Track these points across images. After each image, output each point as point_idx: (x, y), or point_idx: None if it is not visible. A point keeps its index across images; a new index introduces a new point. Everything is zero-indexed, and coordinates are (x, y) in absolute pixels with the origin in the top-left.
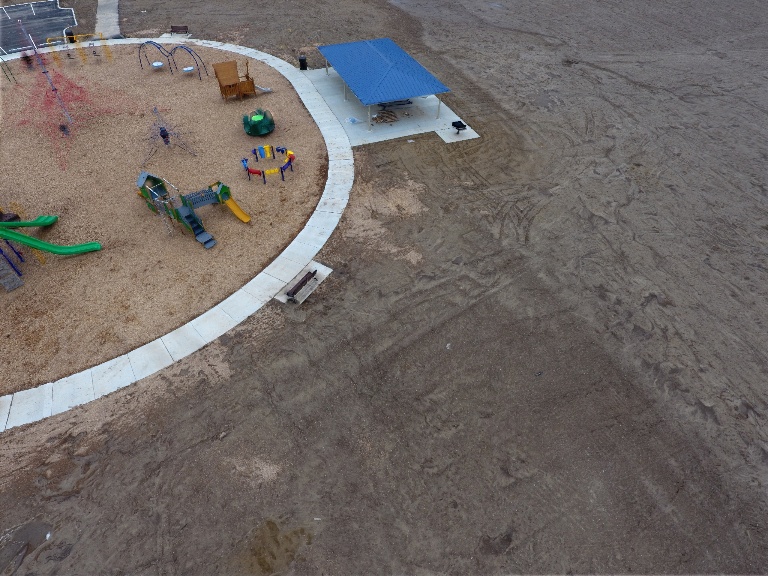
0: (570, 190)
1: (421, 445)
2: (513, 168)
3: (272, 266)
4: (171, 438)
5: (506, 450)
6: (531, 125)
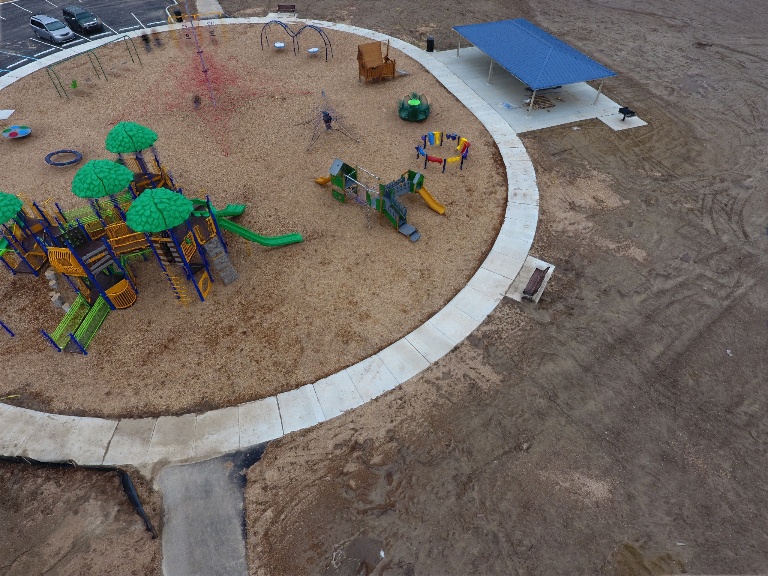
0: (766, 182)
1: (762, 464)
2: (695, 158)
3: (489, 261)
4: (469, 448)
5: None
6: (693, 112)
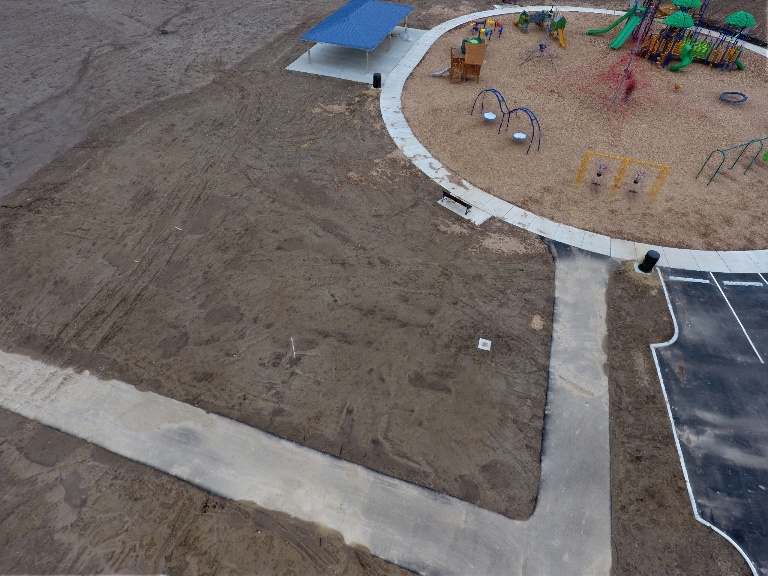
0: None
1: None
2: None
3: None
4: None
5: None
6: None
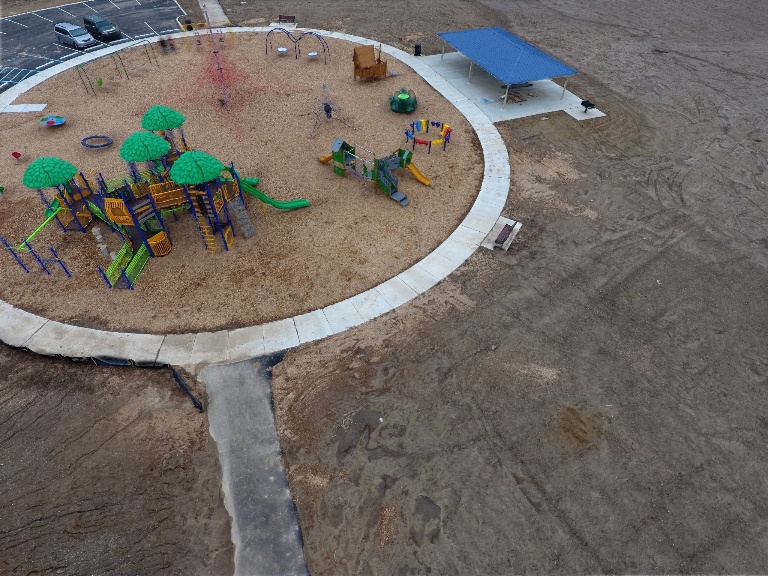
0: (704, 161)
1: (675, 353)
2: (646, 142)
3: (467, 220)
4: (449, 350)
5: (749, 357)
6: (647, 106)
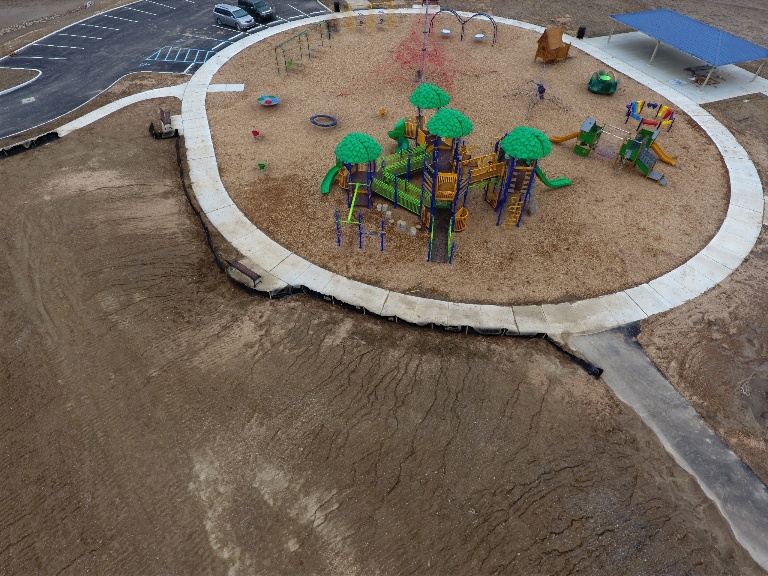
0: None
1: None
2: None
3: (734, 200)
4: None
5: None
6: None
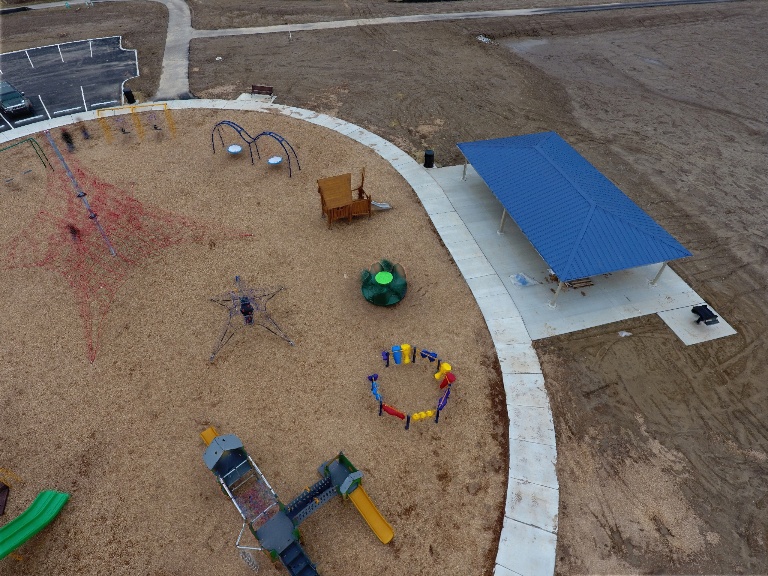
0: None
1: None
2: None
3: None
4: None
5: None
6: None
